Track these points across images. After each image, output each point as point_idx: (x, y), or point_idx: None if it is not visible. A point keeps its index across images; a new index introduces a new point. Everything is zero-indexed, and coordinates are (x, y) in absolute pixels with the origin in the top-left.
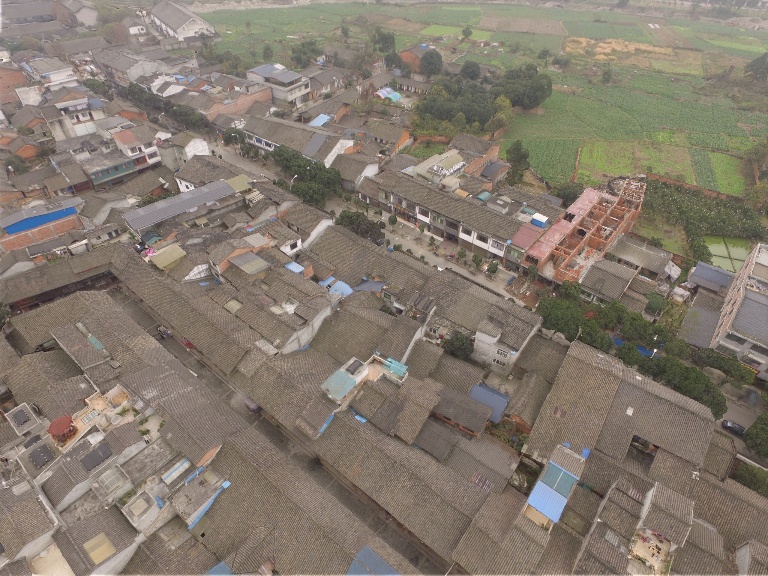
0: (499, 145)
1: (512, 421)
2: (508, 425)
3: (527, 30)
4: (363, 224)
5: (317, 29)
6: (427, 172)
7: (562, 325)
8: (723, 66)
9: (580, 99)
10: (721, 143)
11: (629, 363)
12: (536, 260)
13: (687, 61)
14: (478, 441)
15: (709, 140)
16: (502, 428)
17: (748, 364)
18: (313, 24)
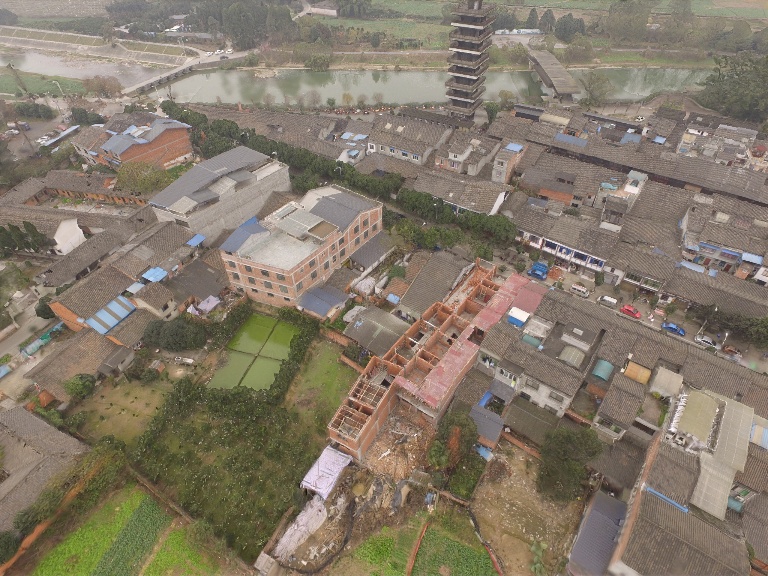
0: (624, 555)
1: None
2: None
3: None
4: (735, 313)
5: None
6: None
7: None
8: None
9: None
10: None
11: None
12: None
13: None
14: None
15: None
16: None
17: None
18: None
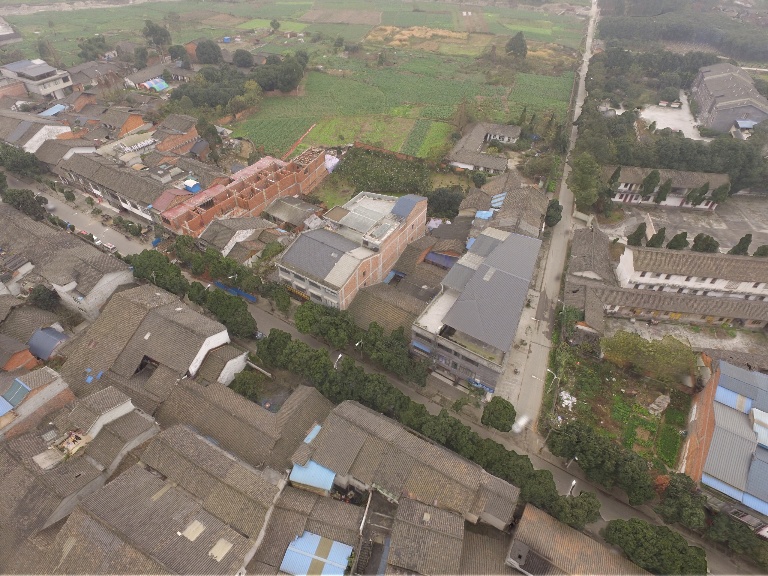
0: None
1: (64, 357)
2: (56, 361)
3: (342, 21)
4: (22, 200)
5: (132, 26)
6: (113, 150)
7: (141, 272)
8: (503, 47)
9: (347, 81)
10: (447, 113)
11: (189, 299)
12: (168, 220)
13: (475, 44)
14: (4, 375)
15: (438, 111)
16: (49, 364)
17: (302, 292)
18: (132, 22)
